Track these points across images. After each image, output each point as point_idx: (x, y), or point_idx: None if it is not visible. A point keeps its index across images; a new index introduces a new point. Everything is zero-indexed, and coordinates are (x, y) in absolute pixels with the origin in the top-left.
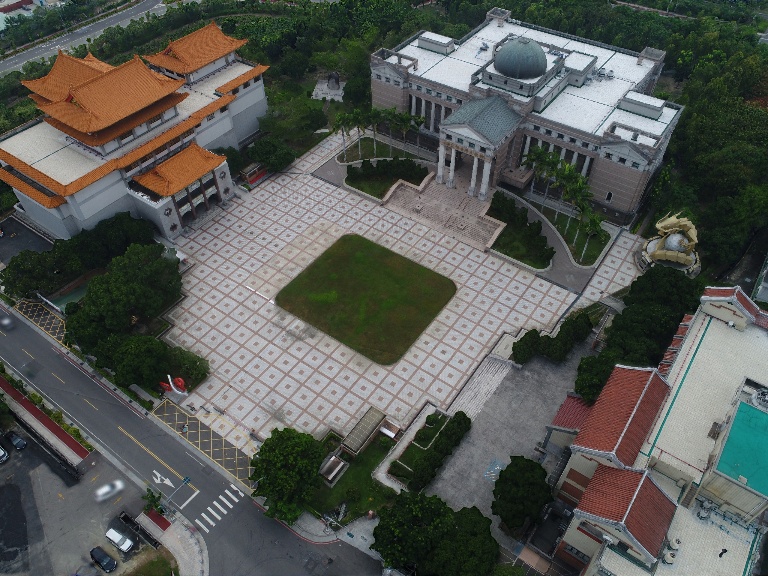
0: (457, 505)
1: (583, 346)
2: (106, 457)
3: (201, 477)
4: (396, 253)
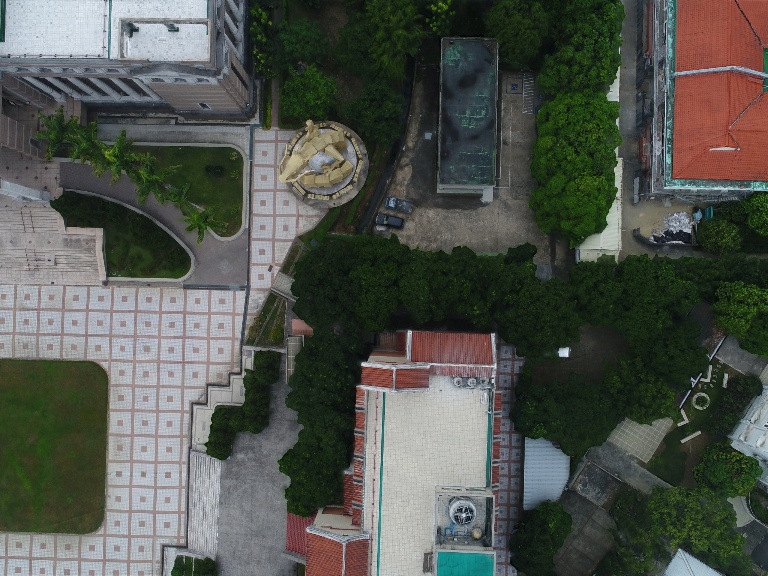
0: None
1: (281, 380)
2: None
3: None
4: (1, 359)
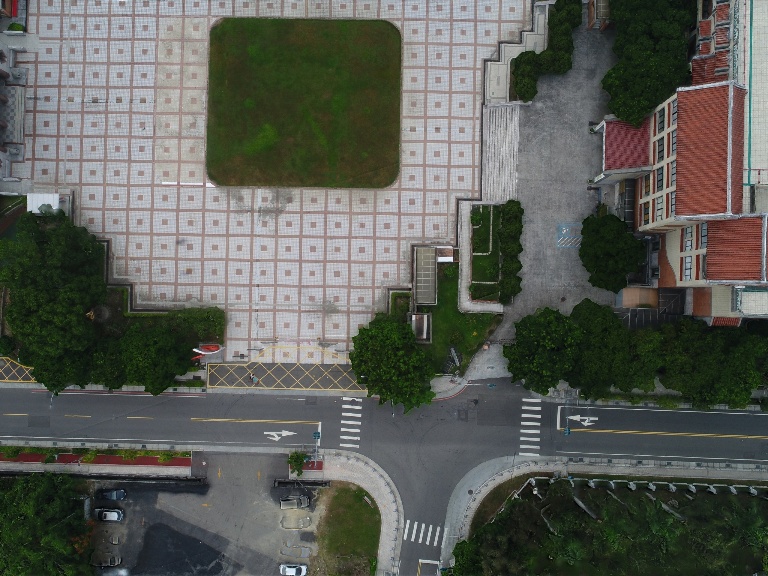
0: (550, 289)
1: (578, 31)
2: (209, 451)
3: (311, 410)
4: (294, 19)
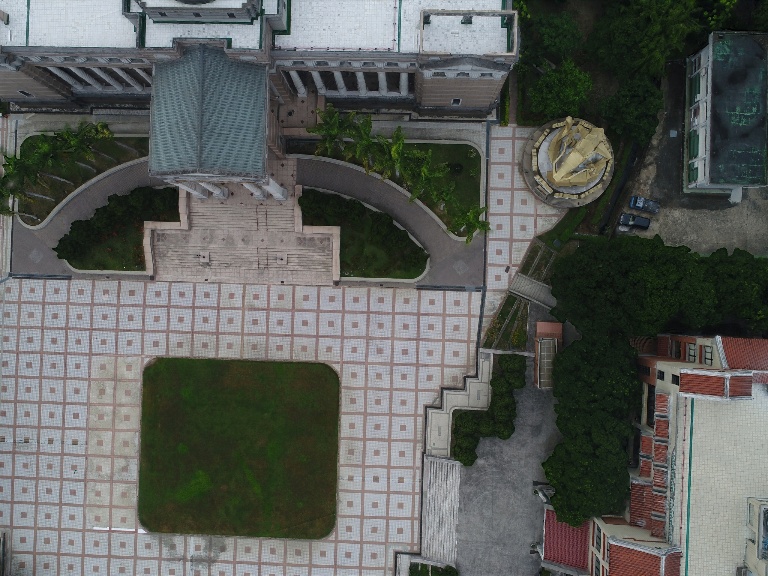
0: None
1: None
2: None
3: None
4: (229, 360)
